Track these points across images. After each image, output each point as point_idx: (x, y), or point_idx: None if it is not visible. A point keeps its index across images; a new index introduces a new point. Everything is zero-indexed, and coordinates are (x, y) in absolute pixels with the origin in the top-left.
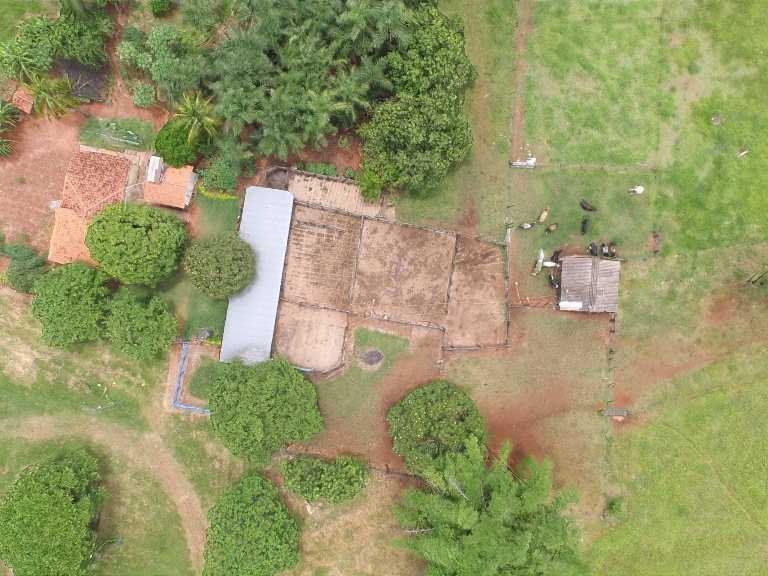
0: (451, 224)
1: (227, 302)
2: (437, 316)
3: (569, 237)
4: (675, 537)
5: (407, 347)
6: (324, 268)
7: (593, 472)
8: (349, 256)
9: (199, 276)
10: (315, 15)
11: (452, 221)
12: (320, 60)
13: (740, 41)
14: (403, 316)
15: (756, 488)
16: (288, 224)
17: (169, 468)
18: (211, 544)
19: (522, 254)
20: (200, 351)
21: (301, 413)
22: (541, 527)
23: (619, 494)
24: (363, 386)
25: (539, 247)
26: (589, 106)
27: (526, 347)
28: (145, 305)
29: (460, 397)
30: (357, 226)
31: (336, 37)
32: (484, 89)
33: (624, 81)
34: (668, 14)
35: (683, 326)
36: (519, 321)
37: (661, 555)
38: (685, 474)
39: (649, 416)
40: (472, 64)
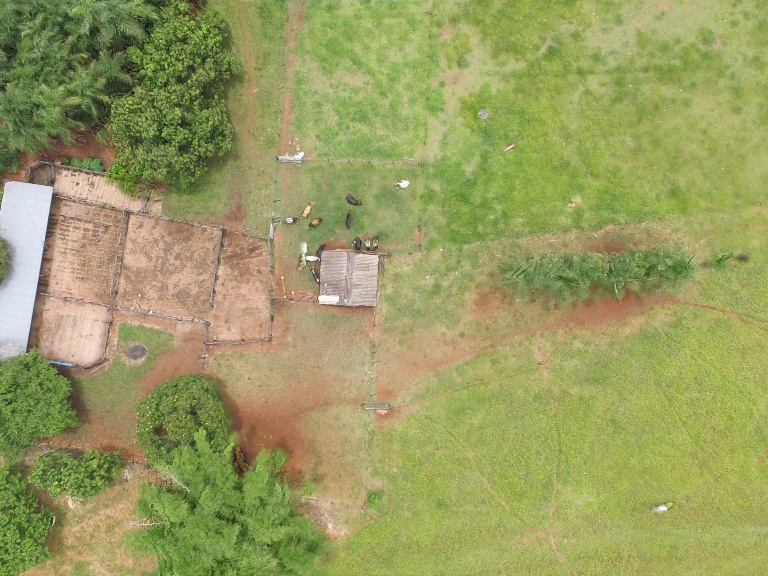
0: (218, 219)
1: None
2: (203, 310)
3: (334, 231)
4: (435, 530)
5: (171, 342)
6: (90, 263)
7: (355, 465)
8: (115, 251)
9: None
10: (48, 9)
11: (219, 216)
12: (55, 54)
13: (509, 36)
14: (167, 311)
15: (515, 480)
16: (46, 219)
17: None
18: None
19: (288, 248)
20: None
21: (44, 407)
22: (249, 519)
23: (380, 487)
24: (127, 381)
25: (304, 241)
26: (358, 101)
27: (291, 341)
28: None
29: (195, 391)
30: (124, 221)
31: (72, 31)
32: (254, 84)
33: (393, 76)
34: (438, 9)
35: (447, 320)
36: (284, 315)
37: (419, 548)
38: (445, 467)
39: (411, 409)
40: (242, 59)
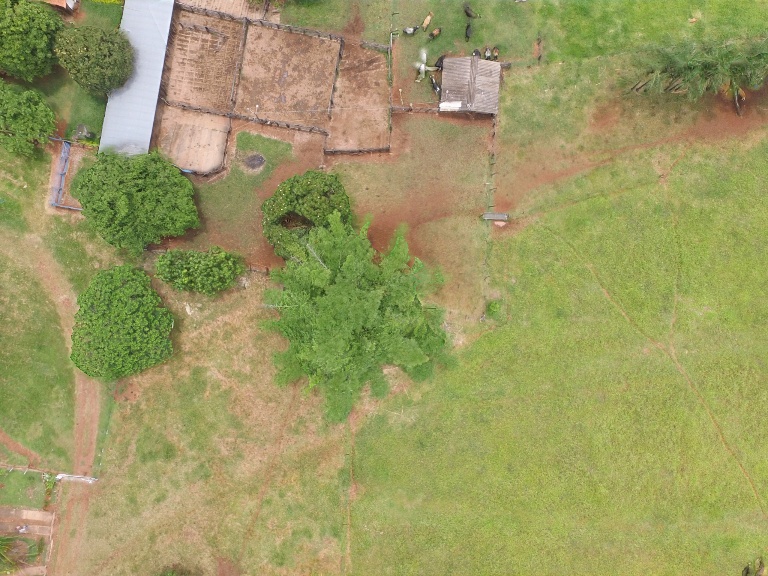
0: (336, 31)
1: (106, 99)
2: (320, 122)
3: (453, 44)
4: (554, 340)
5: (289, 151)
6: (208, 74)
7: (473, 276)
8: (233, 62)
9: (68, 57)
10: None
11: (337, 28)
12: None
13: None
14: (286, 120)
15: (635, 291)
16: (168, 23)
17: (49, 268)
18: (79, 326)
19: (406, 61)
20: (82, 154)
21: (172, 198)
22: (393, 284)
23: (499, 297)
24: (245, 189)
25: (423, 53)
26: None
27: (409, 153)
28: (18, 92)
29: (327, 177)
30: (242, 32)
31: None
32: None
33: None
34: None
35: (566, 133)
36: (402, 127)
37: (539, 357)
38: (565, 277)
39: (530, 221)
40: None
